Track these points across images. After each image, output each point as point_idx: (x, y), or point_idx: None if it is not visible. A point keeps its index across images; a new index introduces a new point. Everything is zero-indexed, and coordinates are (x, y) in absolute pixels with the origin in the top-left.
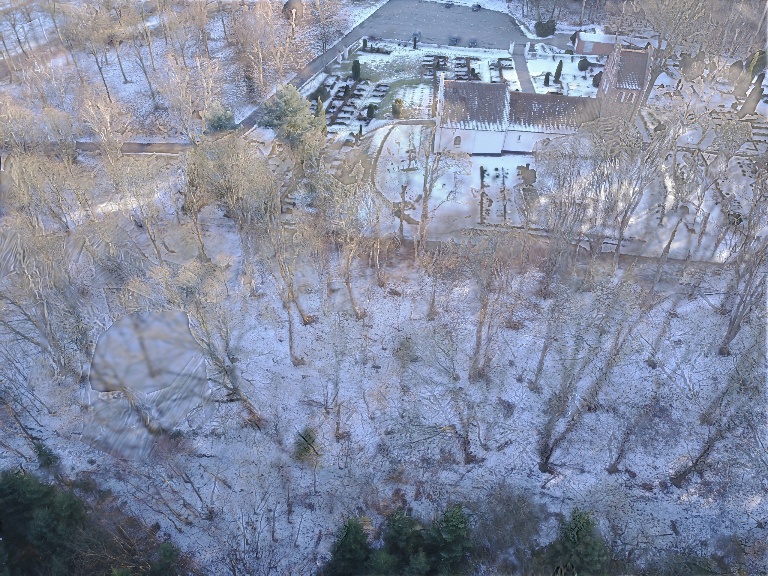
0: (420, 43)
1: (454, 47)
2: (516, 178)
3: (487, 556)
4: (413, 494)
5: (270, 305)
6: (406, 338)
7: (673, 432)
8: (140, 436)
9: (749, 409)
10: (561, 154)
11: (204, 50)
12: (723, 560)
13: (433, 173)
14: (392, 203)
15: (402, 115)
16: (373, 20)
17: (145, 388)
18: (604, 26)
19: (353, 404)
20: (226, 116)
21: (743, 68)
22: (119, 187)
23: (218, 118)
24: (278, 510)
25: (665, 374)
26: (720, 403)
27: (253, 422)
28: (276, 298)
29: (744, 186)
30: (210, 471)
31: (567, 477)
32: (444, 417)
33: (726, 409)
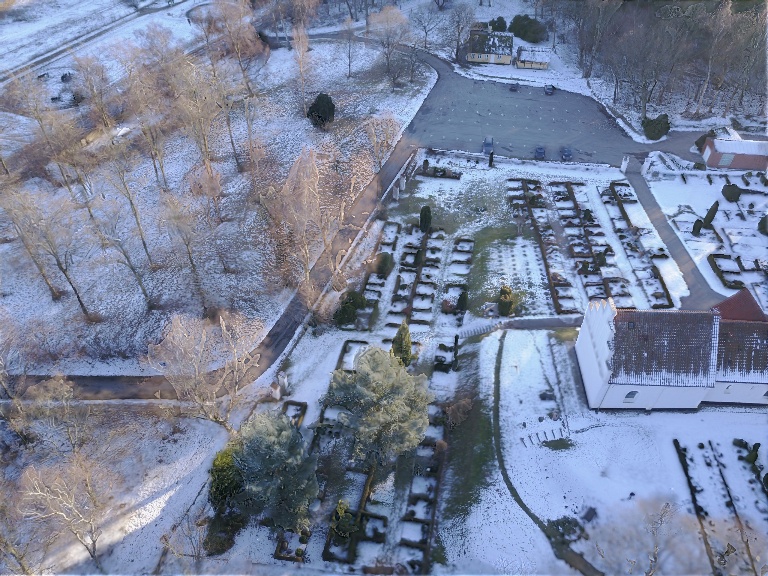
0: (497, 158)
1: (544, 163)
2: (739, 466)
3: None
4: None
5: None
6: None
7: None
8: None
9: None
10: None
11: None
12: None
13: None
14: (546, 523)
15: None
16: (424, 118)
17: None
18: (729, 118)
19: None
20: (280, 439)
21: None
22: None
23: (267, 446)
24: None
25: None
26: None
27: None
28: None
29: None
30: None
31: None
32: None
33: None
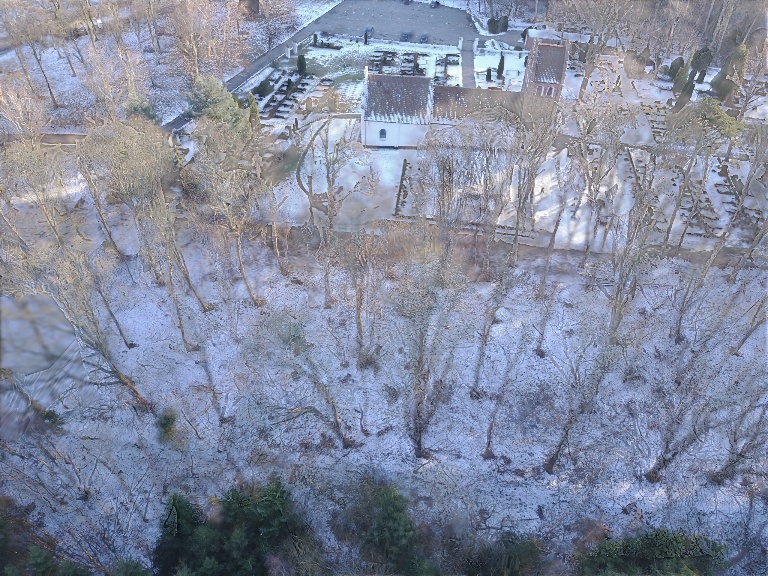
0: (371, 39)
1: (404, 43)
2: None
3: (351, 538)
4: (288, 477)
5: (174, 292)
6: (301, 325)
7: (554, 420)
8: (21, 417)
9: (633, 398)
10: (439, 143)
11: None
12: (584, 544)
13: (334, 163)
14: (313, 195)
15: (339, 109)
16: (329, 16)
17: (23, 370)
18: (557, 23)
19: (225, 387)
20: (142, 107)
21: None
22: (11, 173)
23: (134, 108)
24: (153, 491)
25: (553, 363)
26: (596, 391)
27: (131, 404)
28: (177, 285)
29: (665, 181)
30: (92, 453)
31: (442, 462)
32: (294, 398)
33: (610, 398)
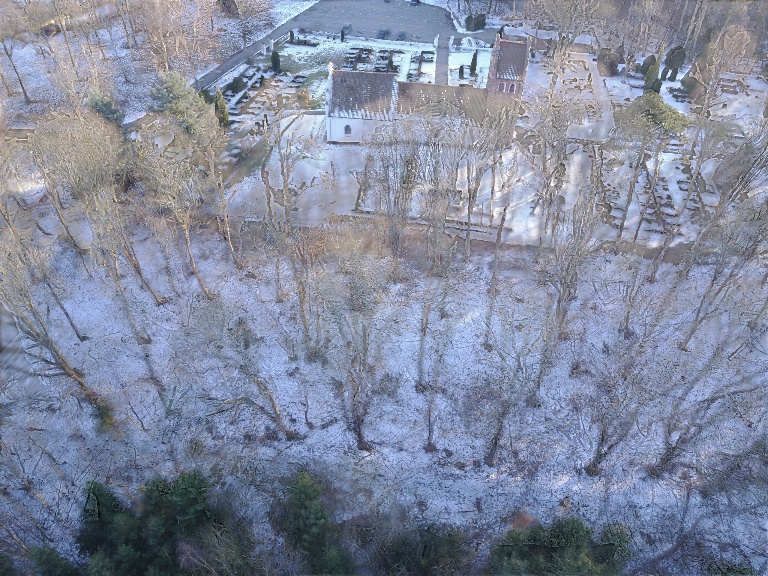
0: (348, 36)
1: (381, 40)
2: None
3: (288, 529)
4: (230, 469)
5: (129, 286)
6: (252, 319)
7: (498, 413)
8: None
9: (579, 392)
10: (382, 138)
11: (136, 41)
12: (519, 536)
13: (288, 158)
14: (276, 190)
15: (310, 105)
16: (309, 13)
17: None
18: (535, 21)
19: (166, 379)
20: (103, 101)
21: (663, 63)
22: None
23: (95, 103)
24: None
25: (500, 357)
26: (538, 385)
27: (74, 396)
28: (131, 279)
29: (628, 177)
30: (38, 444)
31: (383, 455)
32: (225, 389)
33: (555, 392)
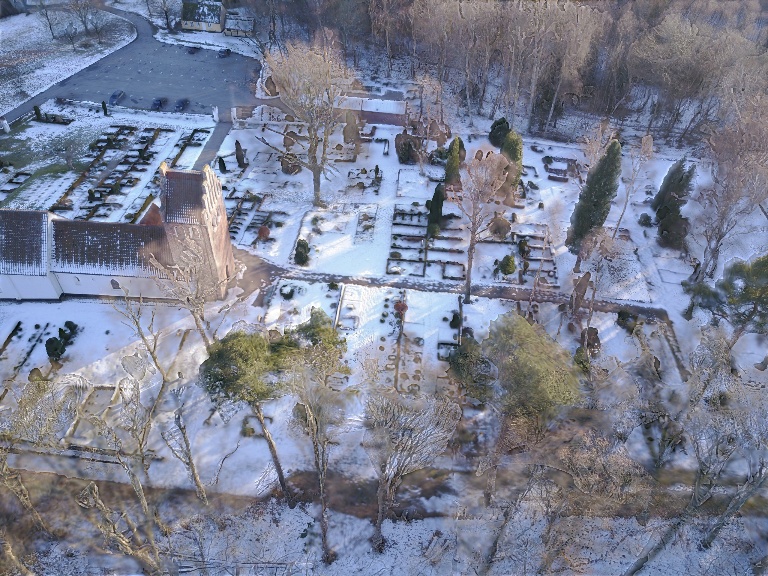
0: (114, 108)
1: (152, 113)
2: None
3: None
4: None
5: None
6: None
7: None
8: None
9: None
10: None
11: None
12: None
13: None
14: None
15: None
16: (85, 74)
17: None
18: (354, 79)
19: None
20: None
21: None
22: None
23: None
24: None
25: None
26: None
27: None
28: None
29: (372, 341)
30: None
31: None
32: None
33: None
